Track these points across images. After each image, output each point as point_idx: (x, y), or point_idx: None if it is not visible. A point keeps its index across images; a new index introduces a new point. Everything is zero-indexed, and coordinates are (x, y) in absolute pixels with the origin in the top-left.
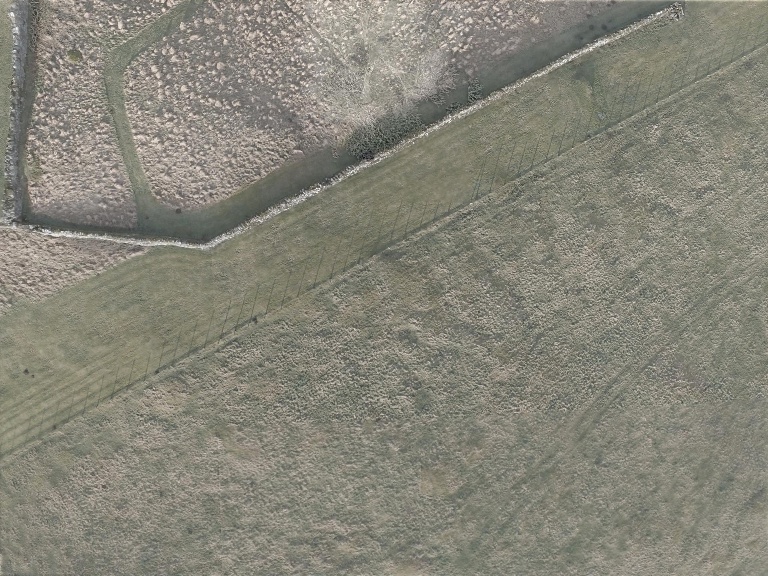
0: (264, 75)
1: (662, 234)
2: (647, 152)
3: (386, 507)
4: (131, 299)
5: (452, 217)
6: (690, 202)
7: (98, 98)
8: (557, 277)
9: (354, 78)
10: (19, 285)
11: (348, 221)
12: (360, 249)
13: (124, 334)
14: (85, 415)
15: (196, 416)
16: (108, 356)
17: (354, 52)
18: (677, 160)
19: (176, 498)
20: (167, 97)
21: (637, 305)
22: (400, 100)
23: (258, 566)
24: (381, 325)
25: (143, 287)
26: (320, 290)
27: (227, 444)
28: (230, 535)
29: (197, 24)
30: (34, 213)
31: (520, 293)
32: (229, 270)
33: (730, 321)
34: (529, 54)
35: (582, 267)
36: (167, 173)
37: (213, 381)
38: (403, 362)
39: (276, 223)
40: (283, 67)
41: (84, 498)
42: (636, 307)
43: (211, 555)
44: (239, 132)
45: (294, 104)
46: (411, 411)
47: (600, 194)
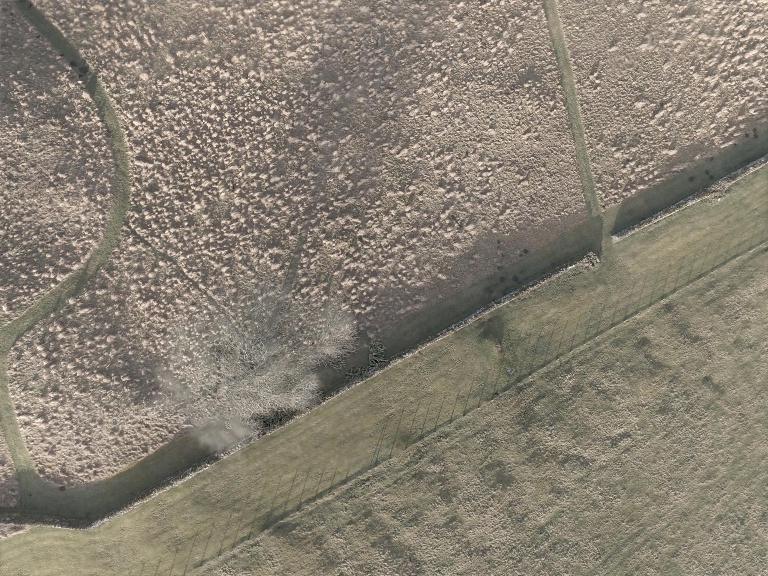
0: (157, 345)
1: (574, 486)
2: (559, 403)
3: None
4: None
5: (350, 484)
6: (605, 451)
7: None
8: (461, 539)
9: (250, 347)
10: None
11: (239, 494)
12: (251, 523)
13: None
14: None
15: None
16: None
17: (251, 319)
18: (591, 409)
19: None
20: (53, 375)
21: (546, 561)
22: (297, 367)
23: None
24: None
25: (24, 565)
26: (208, 566)
27: None
28: None
29: (88, 297)
30: None
31: (421, 557)
32: (114, 548)
33: (647, 570)
34: (435, 311)
35: (487, 528)
36: (51, 452)
37: None
38: None
39: (163, 500)
40: (177, 336)
41: None
42: (545, 563)
43: None
44: (126, 410)
45: (186, 375)
46: None
47: (508, 451)
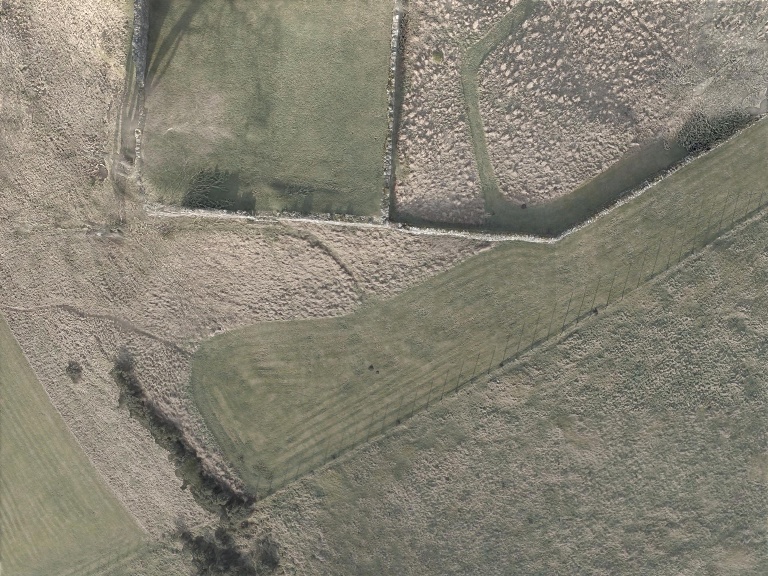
0: (598, 70)
1: None
2: None
3: (716, 493)
4: (477, 294)
5: None
6: None
7: (456, 97)
8: None
9: (683, 71)
10: (371, 283)
11: (681, 212)
12: (693, 239)
13: (469, 328)
14: (429, 409)
15: (538, 407)
16: (453, 350)
17: (681, 45)
18: None
19: (517, 488)
20: (515, 94)
21: None
22: (726, 91)
23: (595, 554)
24: (713, 314)
25: (489, 282)
26: (656, 281)
27: (568, 434)
28: (569, 524)
29: (537, 22)
30: (398, 212)
31: None
32: (571, 263)
33: None
34: None
35: None
36: (515, 169)
37: (555, 373)
38: (732, 350)
39: (616, 216)
40: (615, 62)
41: (427, 490)
42: None
43: (550, 544)
44: (583, 127)
45: (628, 98)
46: (741, 398)
47: None
